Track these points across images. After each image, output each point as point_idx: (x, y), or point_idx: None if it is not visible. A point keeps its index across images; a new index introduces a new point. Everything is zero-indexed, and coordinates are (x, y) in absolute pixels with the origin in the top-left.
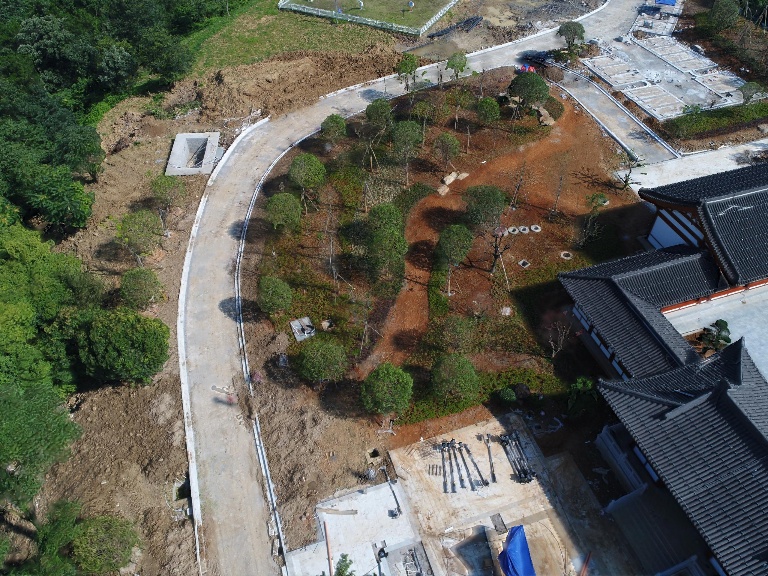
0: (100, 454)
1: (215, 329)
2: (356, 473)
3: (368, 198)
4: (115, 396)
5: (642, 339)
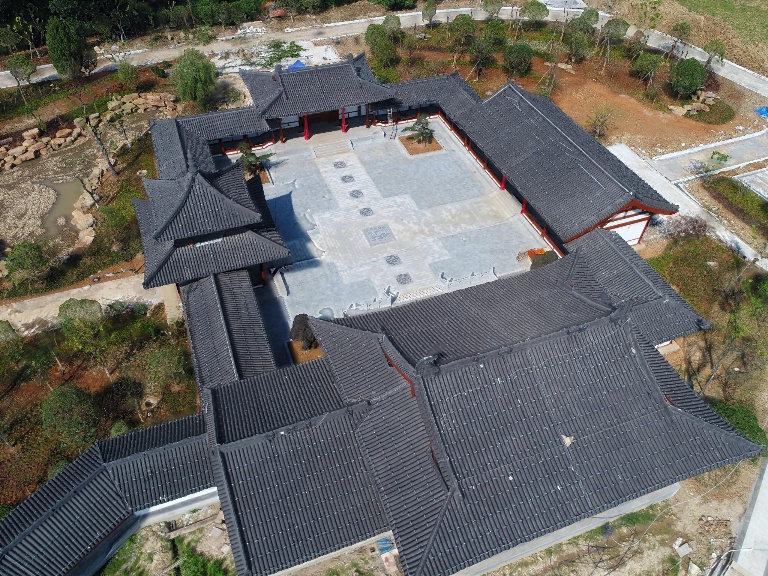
0: (354, 8)
1: (421, 20)
2: (344, 52)
3: (530, 42)
4: (381, 7)
5: None
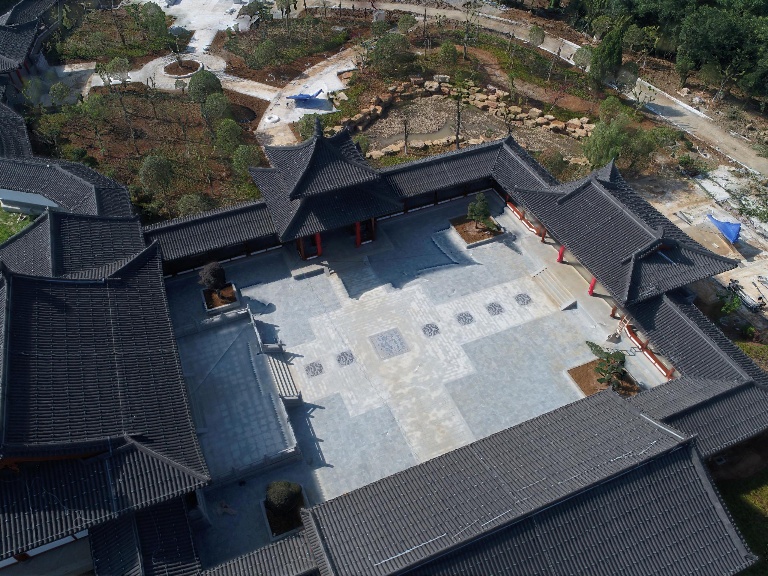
0: None
1: None
2: None
3: None
4: None
5: (699, 327)
